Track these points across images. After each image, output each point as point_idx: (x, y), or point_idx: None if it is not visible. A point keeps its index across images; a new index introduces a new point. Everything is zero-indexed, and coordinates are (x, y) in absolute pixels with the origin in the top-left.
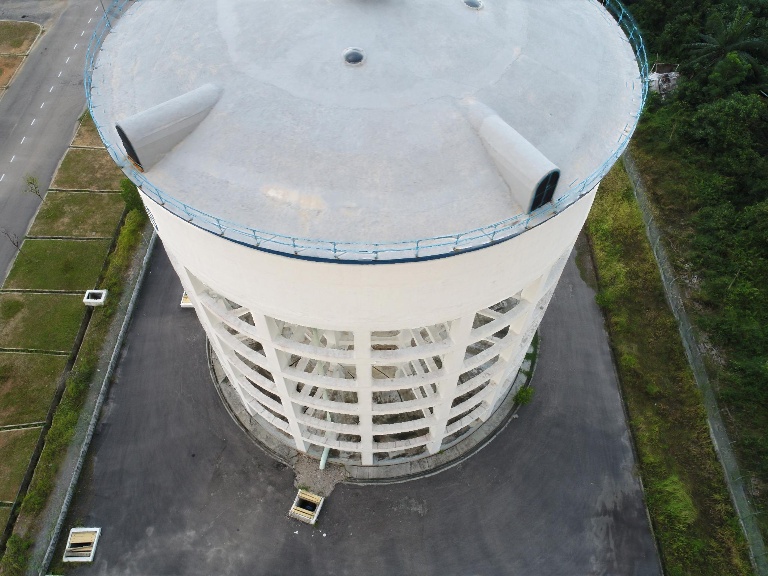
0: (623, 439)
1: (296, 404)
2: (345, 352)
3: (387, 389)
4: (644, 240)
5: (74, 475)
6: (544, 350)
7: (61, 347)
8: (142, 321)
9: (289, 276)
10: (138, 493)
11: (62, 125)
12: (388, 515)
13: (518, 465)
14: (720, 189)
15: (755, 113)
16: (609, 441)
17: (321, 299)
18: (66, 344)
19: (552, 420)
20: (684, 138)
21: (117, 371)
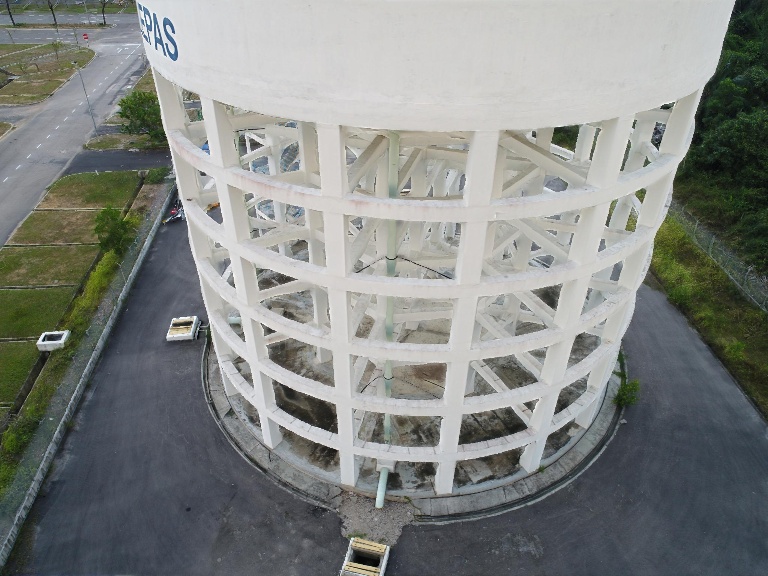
0: (767, 437)
1: (353, 370)
2: (450, 202)
3: (500, 290)
4: (695, 248)
5: (2, 551)
6: (630, 351)
7: (0, 398)
8: (115, 359)
9: (394, 2)
10: (102, 570)
11: (27, 194)
12: (488, 561)
13: (648, 478)
14: (754, 198)
15: (766, 125)
16: (752, 441)
17: (437, 51)
18: (8, 394)
19: (670, 422)
20: (696, 168)
21: (78, 416)
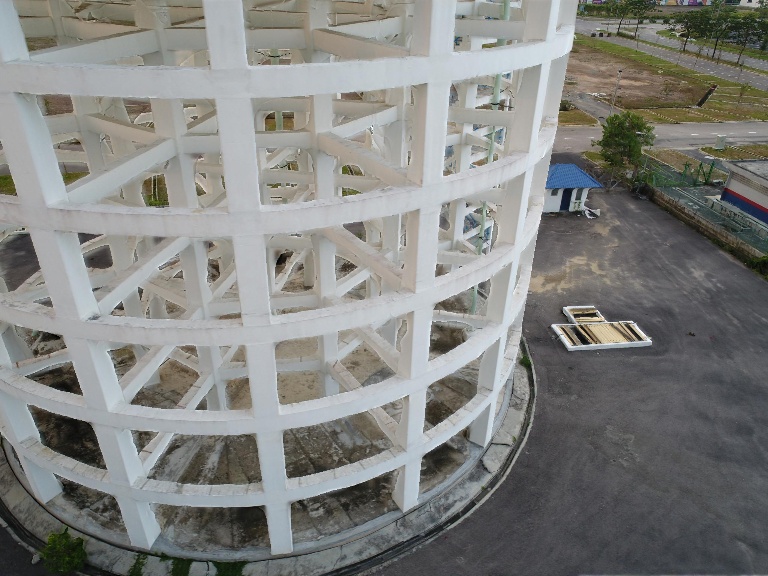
0: None
1: None
2: None
3: None
4: None
5: None
6: None
7: None
8: None
9: None
10: None
11: None
12: None
13: None
14: None
15: None
16: None
17: None
18: None
19: None
20: None
21: None
